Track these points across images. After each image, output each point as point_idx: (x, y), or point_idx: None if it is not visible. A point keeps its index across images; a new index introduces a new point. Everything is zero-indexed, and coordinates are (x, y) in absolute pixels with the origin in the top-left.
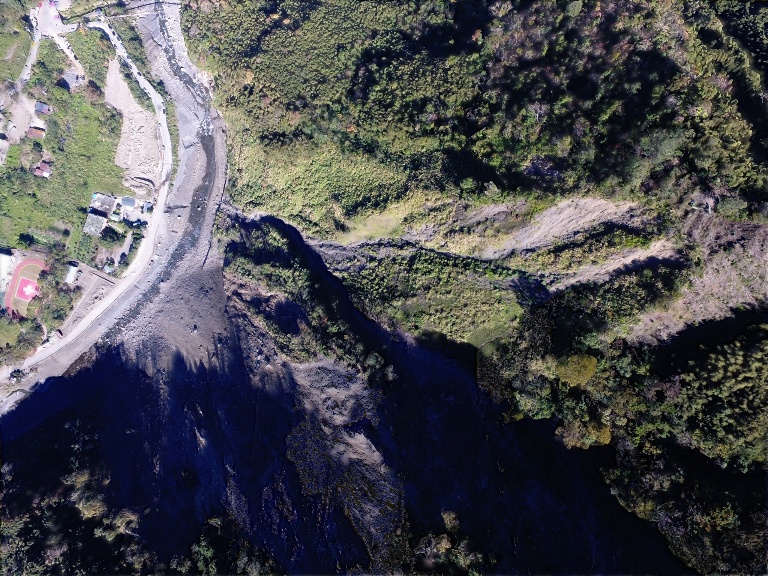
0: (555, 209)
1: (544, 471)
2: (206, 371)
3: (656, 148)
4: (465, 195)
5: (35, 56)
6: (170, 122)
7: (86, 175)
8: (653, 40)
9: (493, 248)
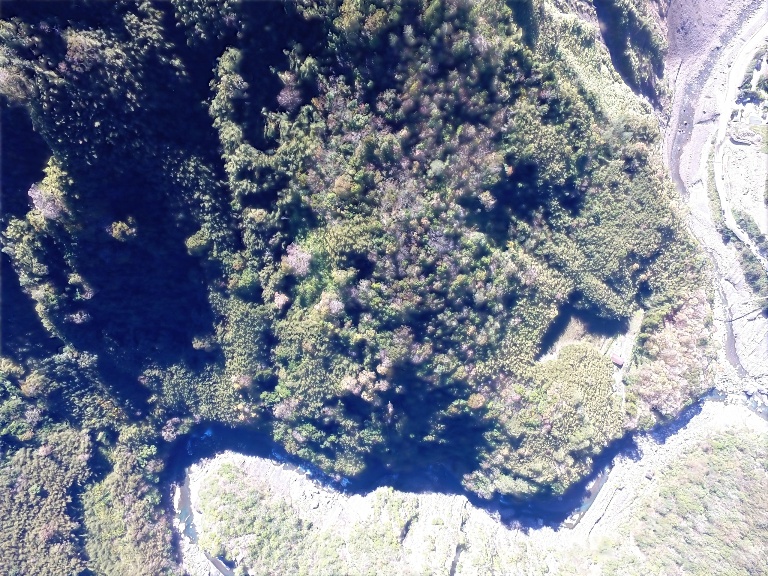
0: None
1: None
2: None
3: None
4: None
5: None
6: (717, 203)
7: None
8: (371, 114)
9: None
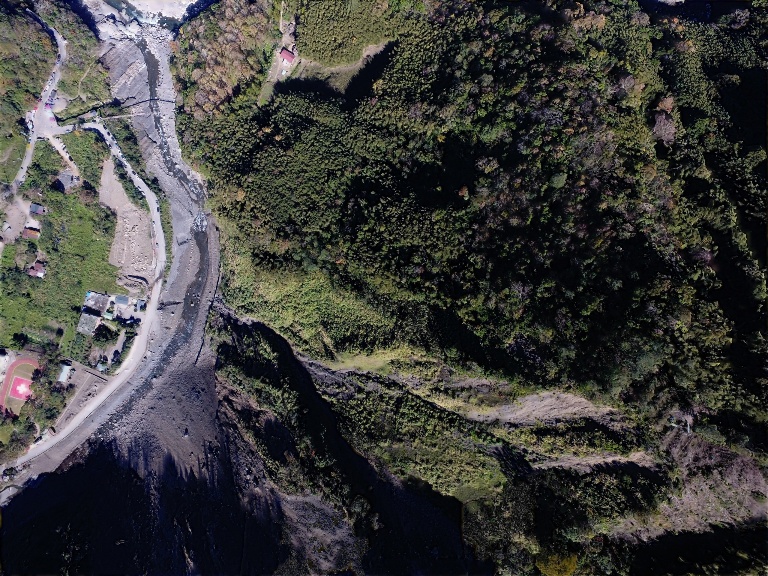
0: (537, 396)
1: None
2: (196, 481)
3: (635, 362)
4: (449, 363)
5: (30, 158)
6: (164, 220)
7: (80, 274)
8: (636, 222)
9: (477, 412)
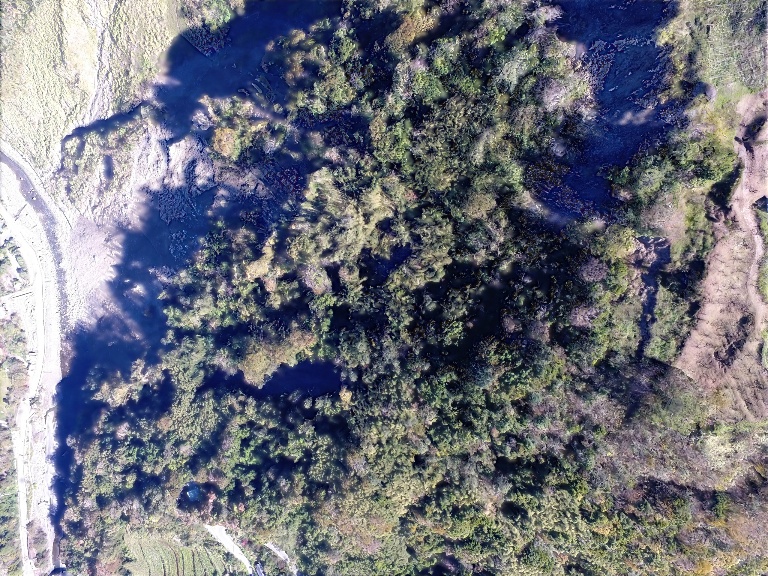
0: None
1: (253, 39)
2: (118, 266)
3: None
4: None
5: None
6: None
7: None
8: None
9: None
